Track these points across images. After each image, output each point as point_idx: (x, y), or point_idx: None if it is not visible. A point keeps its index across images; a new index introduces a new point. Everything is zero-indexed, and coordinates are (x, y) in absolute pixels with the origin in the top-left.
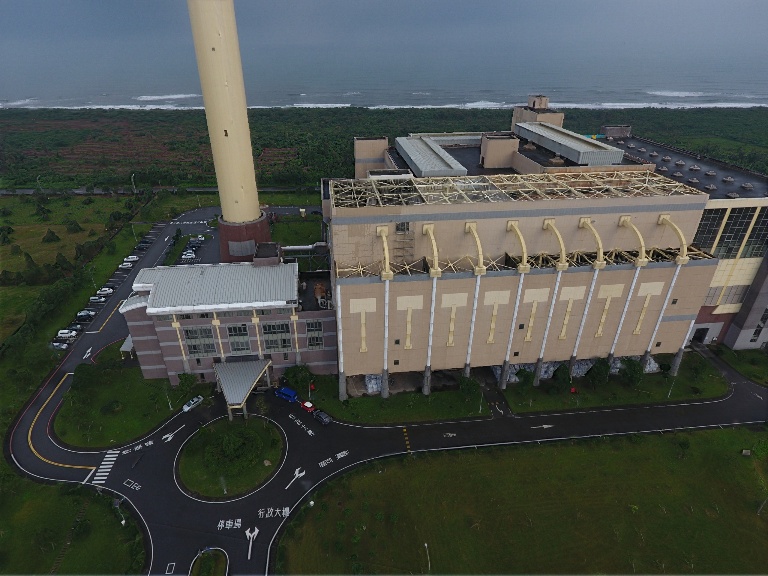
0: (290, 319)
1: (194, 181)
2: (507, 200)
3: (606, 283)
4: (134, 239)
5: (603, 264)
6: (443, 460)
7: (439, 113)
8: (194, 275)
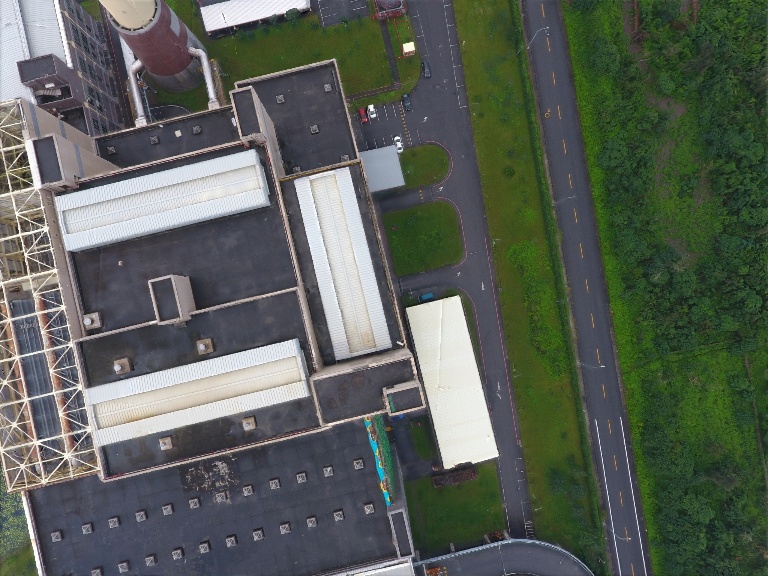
0: None
1: None
2: None
3: None
4: None
5: None
6: None
7: None
8: (4, 19)
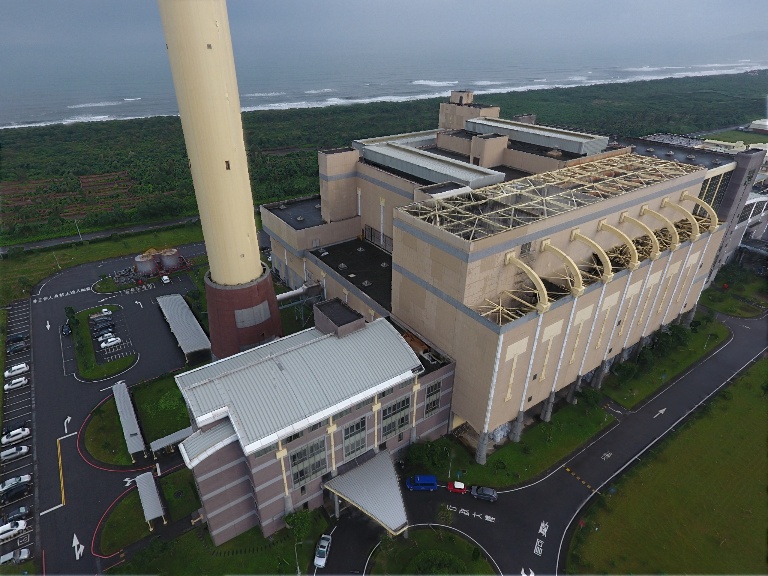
0: (412, 390)
1: (18, 235)
2: (597, 200)
3: (673, 263)
4: None
5: (679, 246)
6: (631, 486)
7: (262, 116)
8: (273, 374)
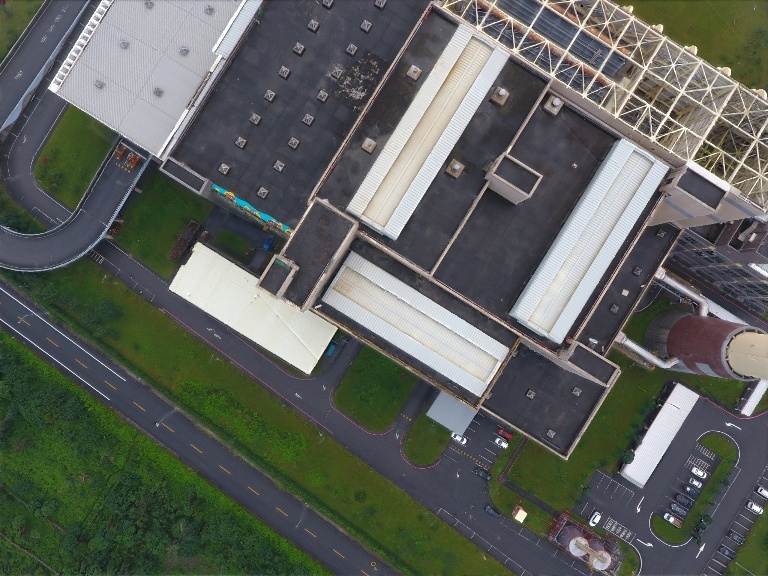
0: None
1: None
2: (668, 45)
3: None
4: (739, 569)
5: None
6: None
7: None
8: None
